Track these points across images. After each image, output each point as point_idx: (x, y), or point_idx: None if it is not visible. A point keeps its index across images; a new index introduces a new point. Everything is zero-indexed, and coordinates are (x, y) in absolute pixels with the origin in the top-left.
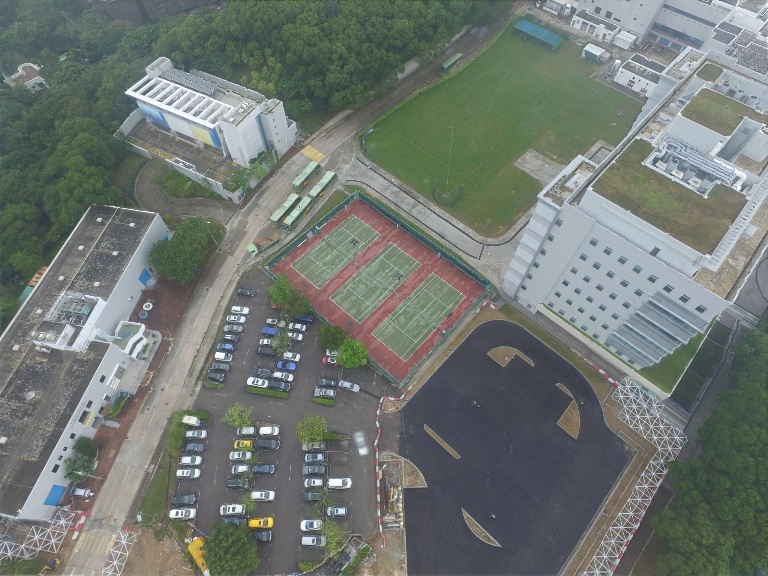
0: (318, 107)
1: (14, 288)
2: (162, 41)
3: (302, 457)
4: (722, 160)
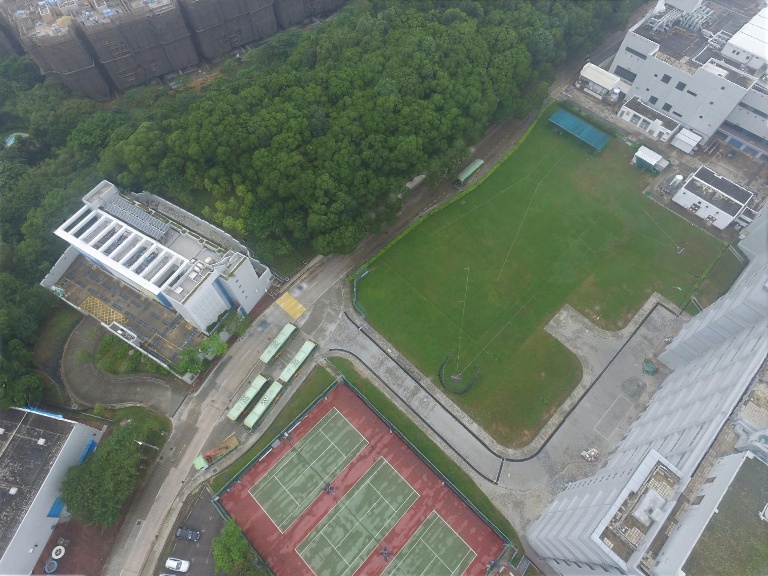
0: (299, 247)
1: None
2: (106, 160)
3: None
4: None
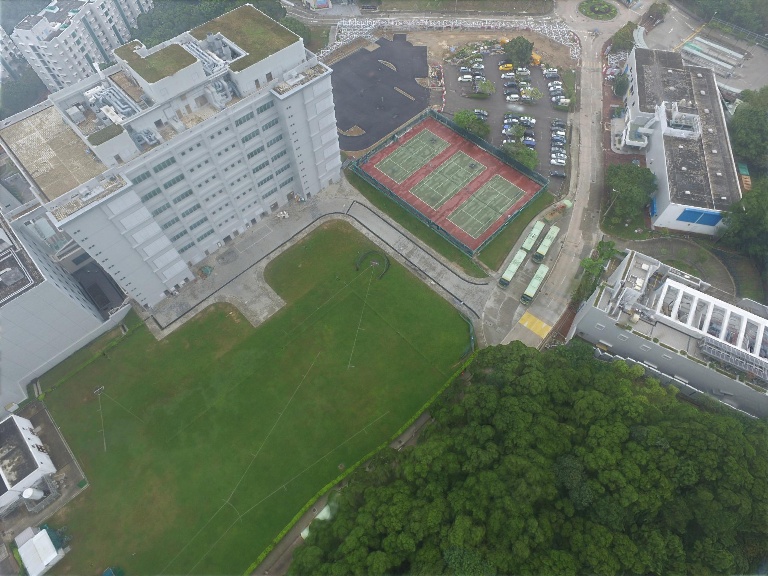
0: None
1: (759, 174)
2: None
3: None
4: None
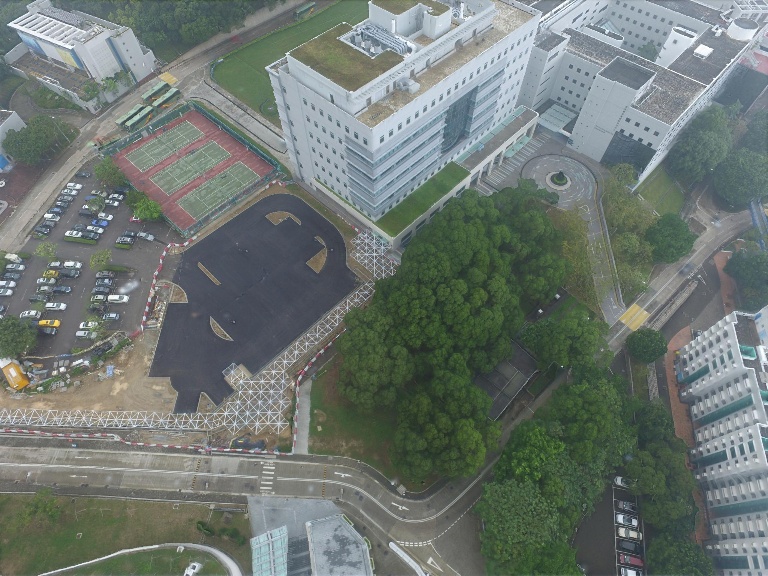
0: (173, 39)
1: None
2: None
3: (95, 283)
4: (401, 36)
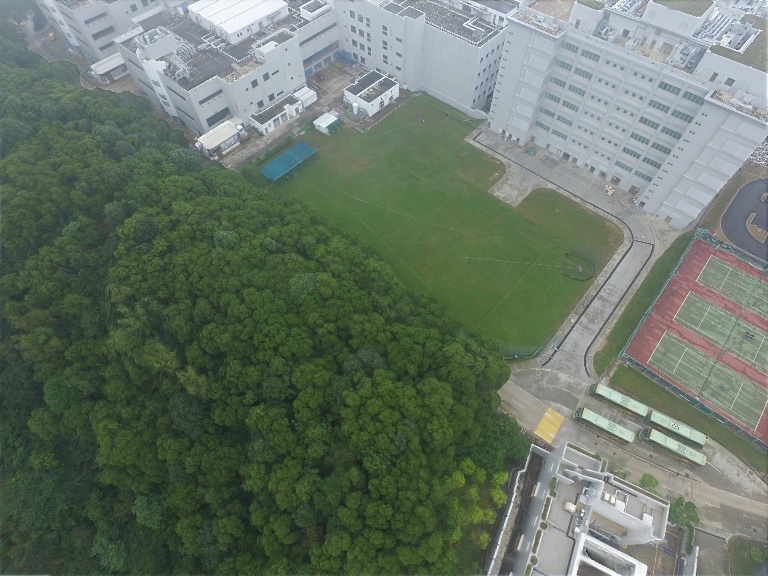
0: None
1: None
2: None
3: None
4: None
